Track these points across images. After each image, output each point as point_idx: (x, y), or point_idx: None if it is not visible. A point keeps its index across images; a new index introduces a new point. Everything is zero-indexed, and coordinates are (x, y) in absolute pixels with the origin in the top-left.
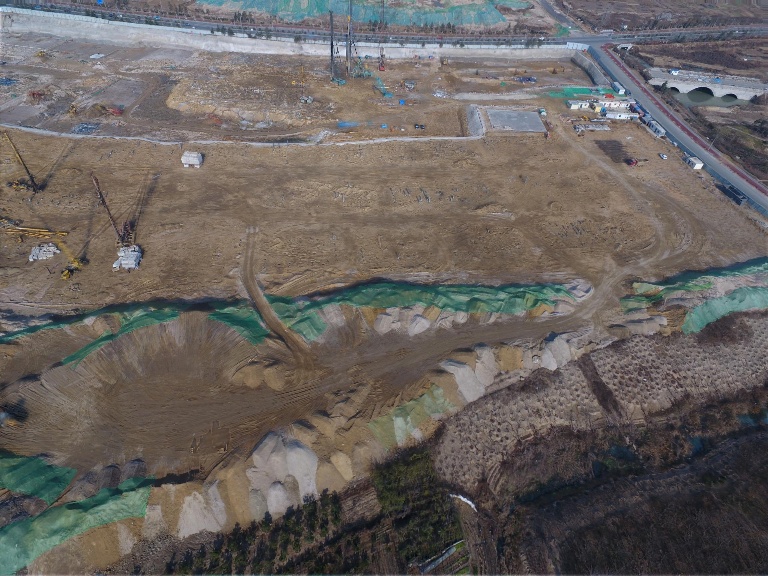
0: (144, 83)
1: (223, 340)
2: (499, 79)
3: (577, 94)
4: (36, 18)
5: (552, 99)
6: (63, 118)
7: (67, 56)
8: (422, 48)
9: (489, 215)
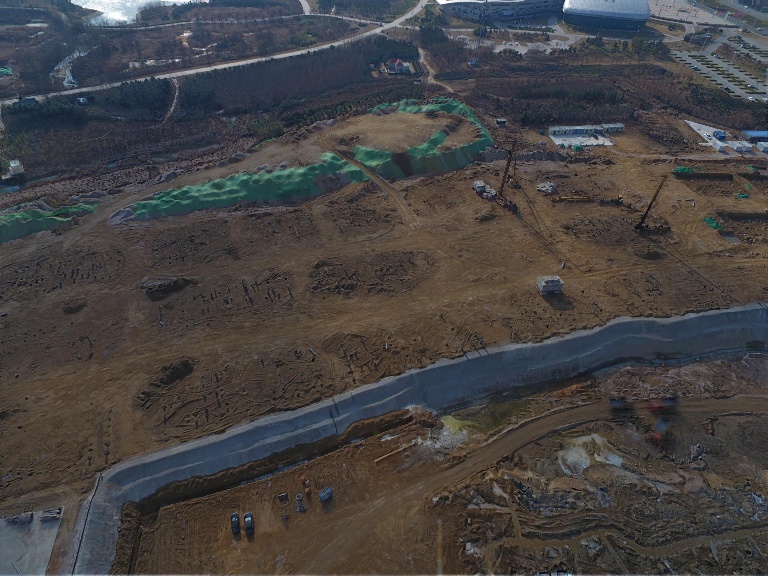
0: None
1: (374, 145)
2: None
3: None
4: None
5: None
6: None
7: None
8: None
9: (173, 278)
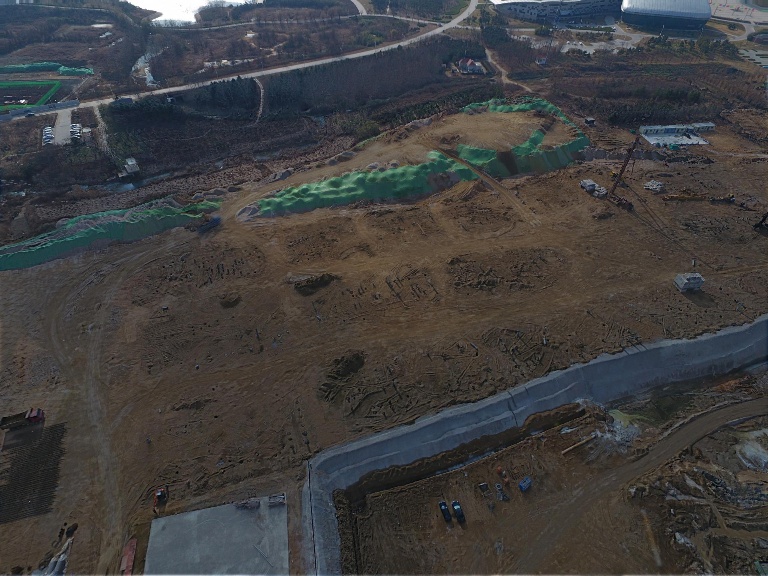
0: None
1: (477, 144)
2: None
3: None
4: None
5: None
6: None
7: None
8: None
9: (317, 274)
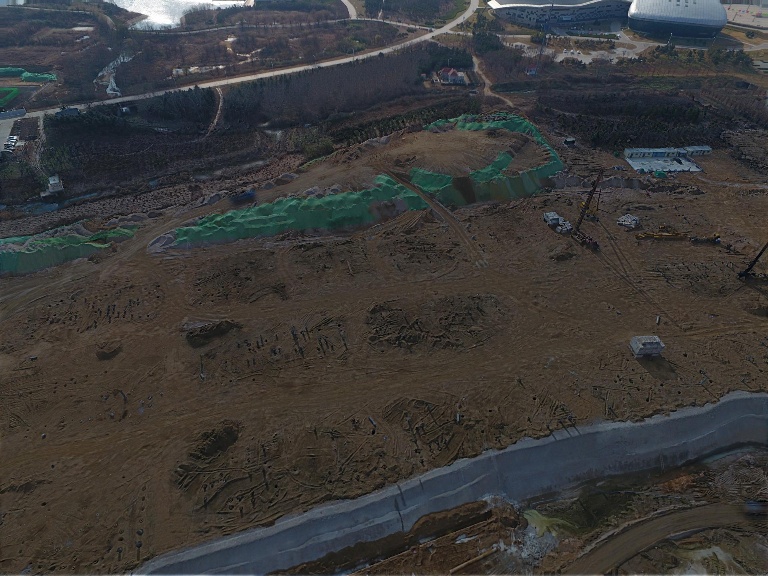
0: None
1: (433, 167)
2: None
3: None
4: None
5: None
6: None
7: None
8: None
9: (216, 320)
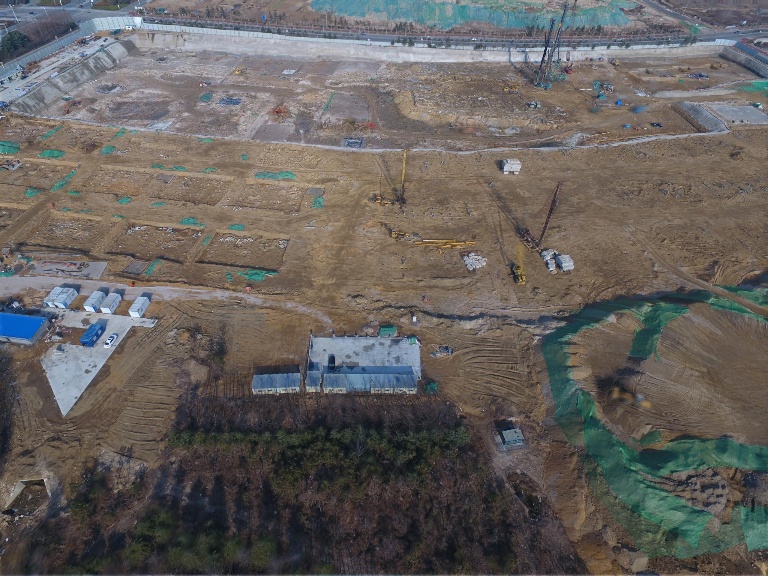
0: (359, 96)
1: (750, 326)
2: (676, 77)
3: (767, 87)
4: (208, 36)
5: (751, 93)
6: (322, 134)
7: (261, 73)
8: (592, 50)
9: None
